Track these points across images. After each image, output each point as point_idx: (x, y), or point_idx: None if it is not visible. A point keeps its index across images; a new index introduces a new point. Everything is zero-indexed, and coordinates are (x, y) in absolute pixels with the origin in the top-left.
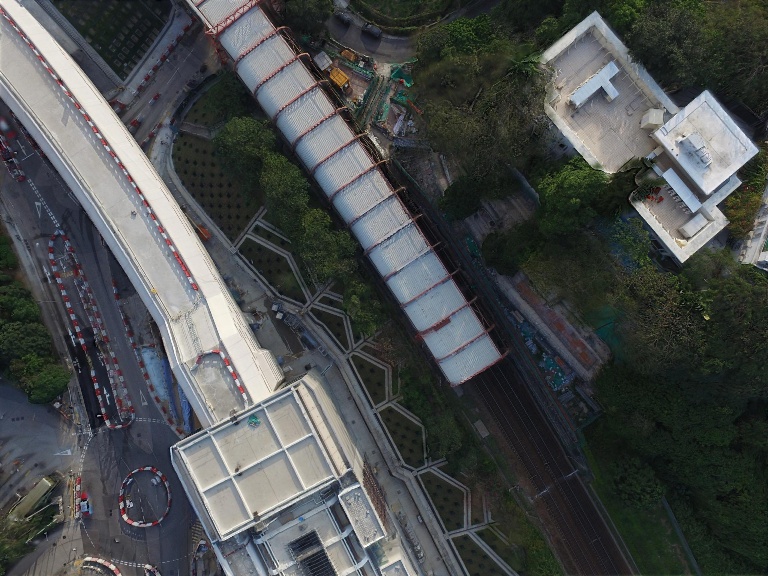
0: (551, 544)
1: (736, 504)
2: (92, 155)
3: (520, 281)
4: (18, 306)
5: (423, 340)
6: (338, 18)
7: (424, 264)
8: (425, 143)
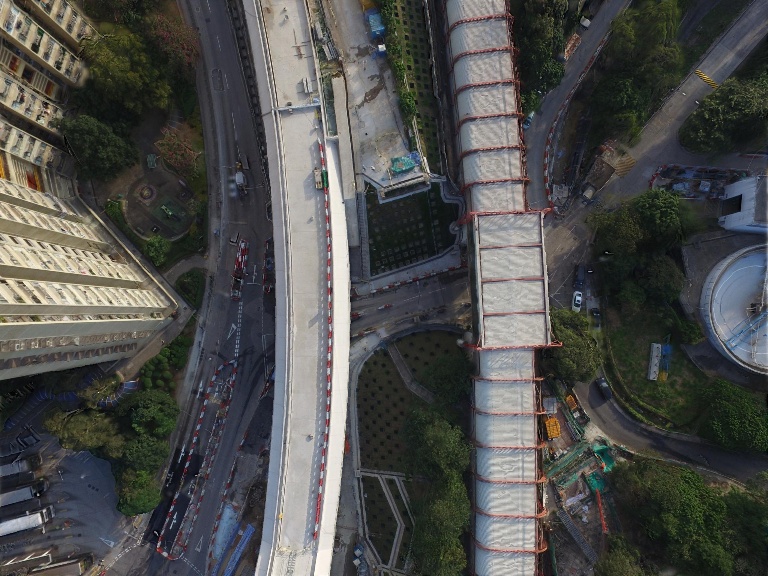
0: None
1: None
2: (312, 366)
3: None
4: (164, 425)
5: None
6: None
7: None
8: (589, 550)
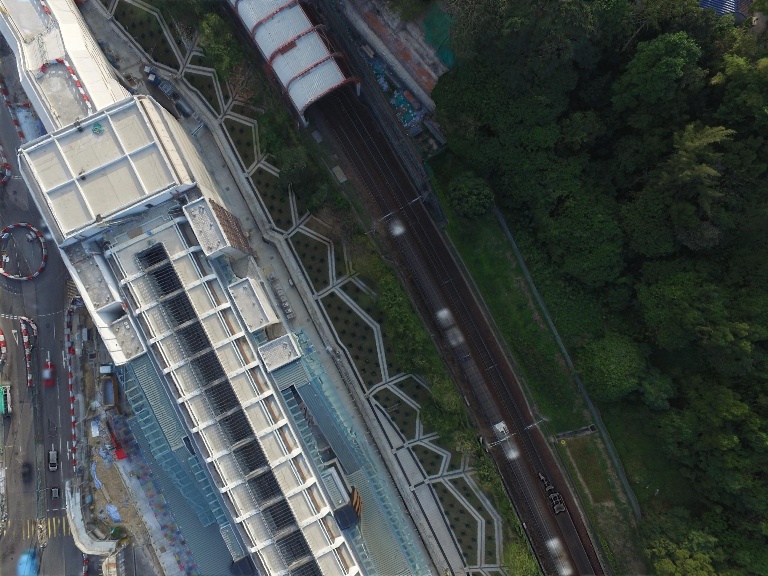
0: (405, 286)
1: (563, 213)
2: None
3: (368, 11)
4: None
5: (274, 71)
6: None
7: None
8: None
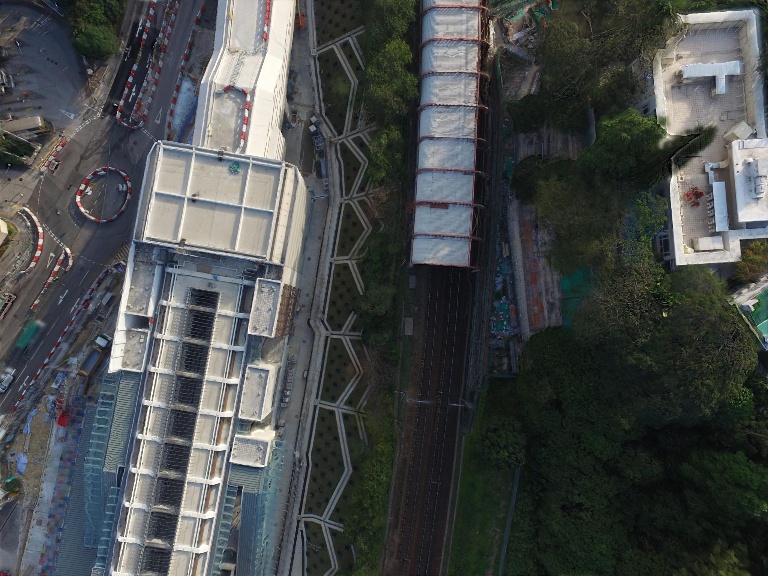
0: (397, 460)
1: (574, 518)
2: None
3: (528, 219)
4: None
5: (415, 212)
6: None
7: (460, 148)
8: (532, 57)
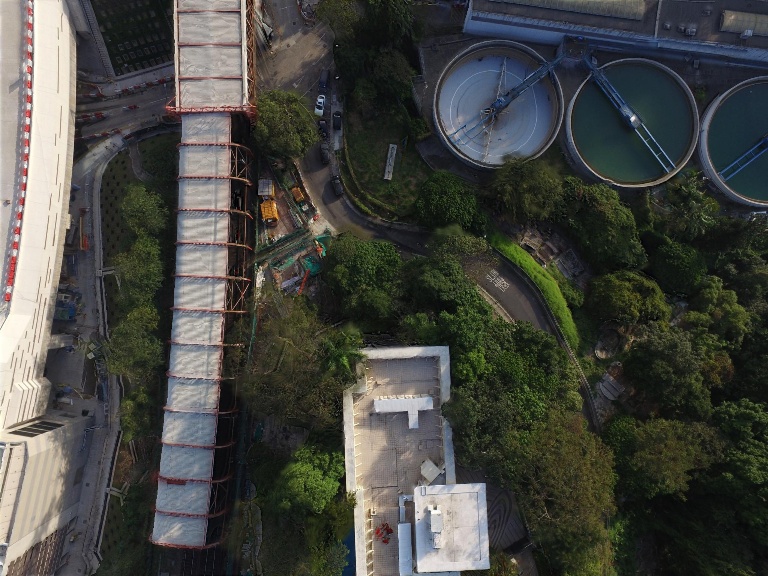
0: None
1: None
2: (12, 131)
3: None
4: None
5: None
6: (321, 154)
7: (201, 421)
8: None
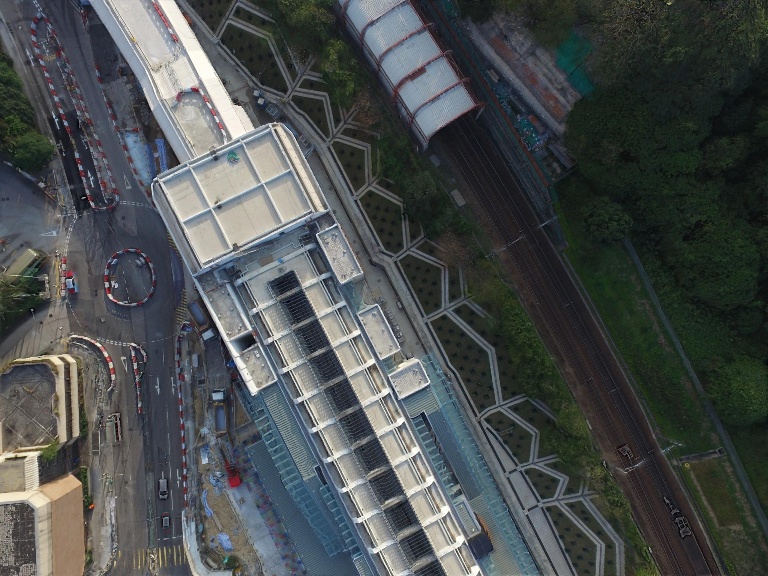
0: (525, 310)
1: (701, 238)
2: None
3: (495, 36)
4: (1, 68)
5: (400, 97)
6: None
7: (400, 15)
8: None
